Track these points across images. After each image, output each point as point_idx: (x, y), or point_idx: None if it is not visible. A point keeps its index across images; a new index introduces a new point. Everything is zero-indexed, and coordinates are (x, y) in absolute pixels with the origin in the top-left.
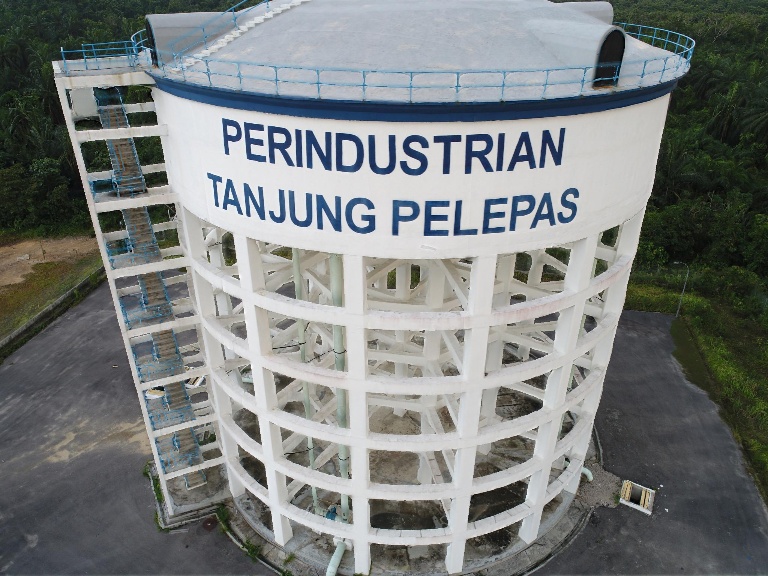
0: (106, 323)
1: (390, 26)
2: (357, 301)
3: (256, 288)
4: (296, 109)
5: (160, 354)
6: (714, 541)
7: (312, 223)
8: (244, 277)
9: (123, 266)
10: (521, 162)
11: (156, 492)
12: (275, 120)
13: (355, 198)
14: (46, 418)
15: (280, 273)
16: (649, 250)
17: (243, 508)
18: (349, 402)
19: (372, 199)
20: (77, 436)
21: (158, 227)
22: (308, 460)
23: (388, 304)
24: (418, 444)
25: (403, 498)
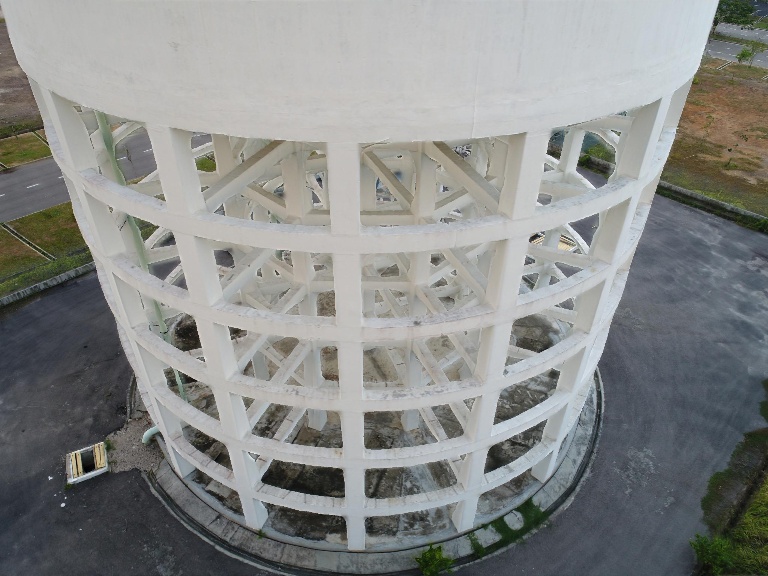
0: (688, 235)
1: None
2: None
3: None
4: None
5: None
6: None
7: None
8: None
9: None
10: None
11: None
12: None
13: None
14: None
15: None
16: None
17: None
18: None
19: None
20: None
21: None
22: None
23: None
24: None
25: None
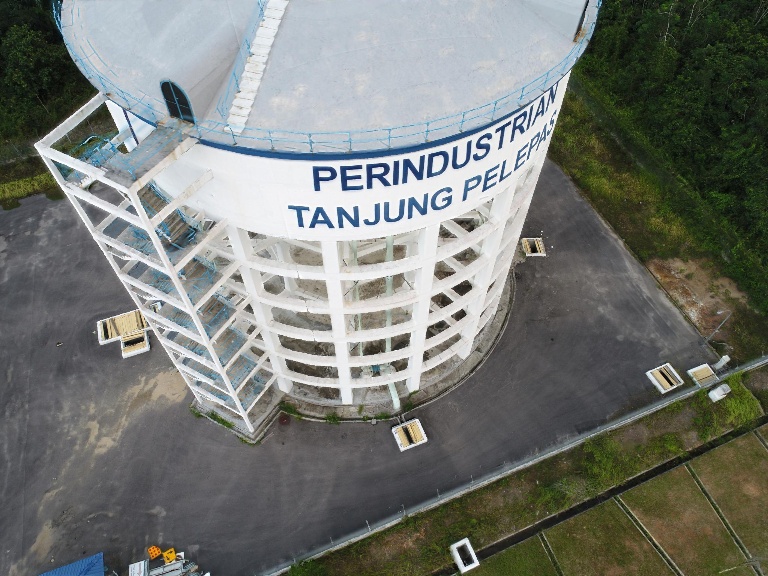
0: None
1: (414, 26)
2: (433, 250)
3: None
4: (400, 150)
5: None
6: (584, 254)
7: (403, 217)
8: (330, 266)
9: (197, 298)
10: (538, 116)
11: (222, 423)
12: (376, 160)
13: (439, 190)
14: (49, 424)
15: None
16: None
17: (301, 396)
18: (418, 308)
19: (451, 186)
20: (100, 422)
21: None
22: None
23: None
24: (460, 307)
25: None
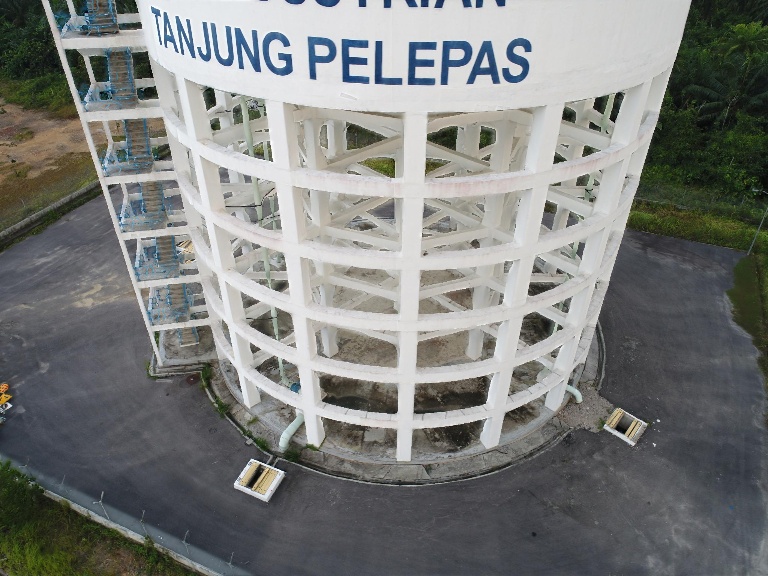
0: None
1: None
2: (283, 154)
3: (201, 137)
4: None
5: (147, 209)
6: (697, 484)
7: (234, 61)
8: (189, 124)
9: (96, 110)
10: None
11: None
12: None
13: (270, 32)
14: (82, 269)
15: (234, 127)
16: (739, 179)
17: (224, 370)
18: None
19: (287, 34)
20: (103, 288)
21: (151, 81)
22: None
23: None
24: (355, 320)
25: (345, 375)
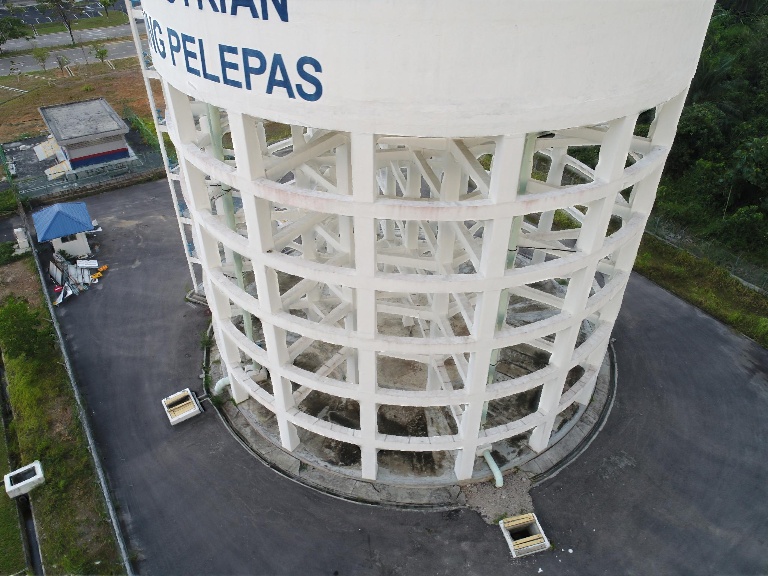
0: None
1: None
2: None
3: None
4: None
5: None
6: None
7: None
8: None
9: None
10: (242, 7)
11: None
12: None
13: None
14: None
15: None
16: None
17: None
18: None
19: (159, 23)
20: None
21: None
22: (303, 312)
23: (320, 177)
24: (231, 294)
25: (236, 343)
